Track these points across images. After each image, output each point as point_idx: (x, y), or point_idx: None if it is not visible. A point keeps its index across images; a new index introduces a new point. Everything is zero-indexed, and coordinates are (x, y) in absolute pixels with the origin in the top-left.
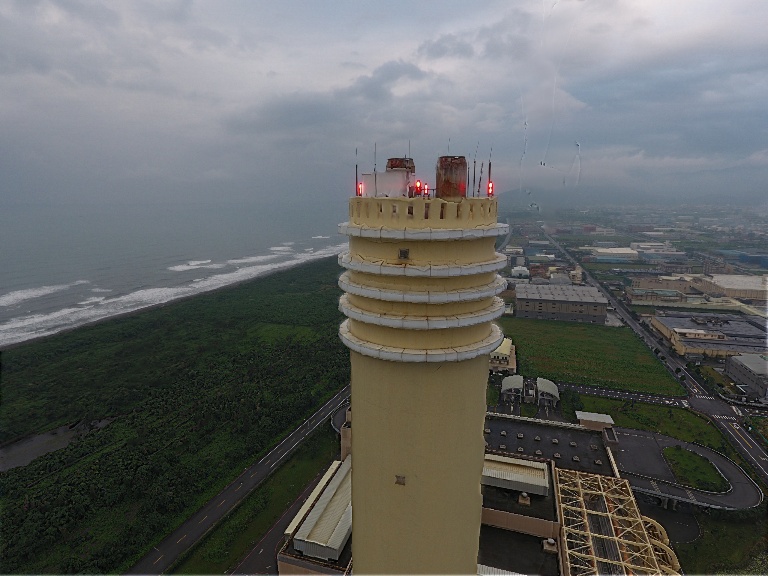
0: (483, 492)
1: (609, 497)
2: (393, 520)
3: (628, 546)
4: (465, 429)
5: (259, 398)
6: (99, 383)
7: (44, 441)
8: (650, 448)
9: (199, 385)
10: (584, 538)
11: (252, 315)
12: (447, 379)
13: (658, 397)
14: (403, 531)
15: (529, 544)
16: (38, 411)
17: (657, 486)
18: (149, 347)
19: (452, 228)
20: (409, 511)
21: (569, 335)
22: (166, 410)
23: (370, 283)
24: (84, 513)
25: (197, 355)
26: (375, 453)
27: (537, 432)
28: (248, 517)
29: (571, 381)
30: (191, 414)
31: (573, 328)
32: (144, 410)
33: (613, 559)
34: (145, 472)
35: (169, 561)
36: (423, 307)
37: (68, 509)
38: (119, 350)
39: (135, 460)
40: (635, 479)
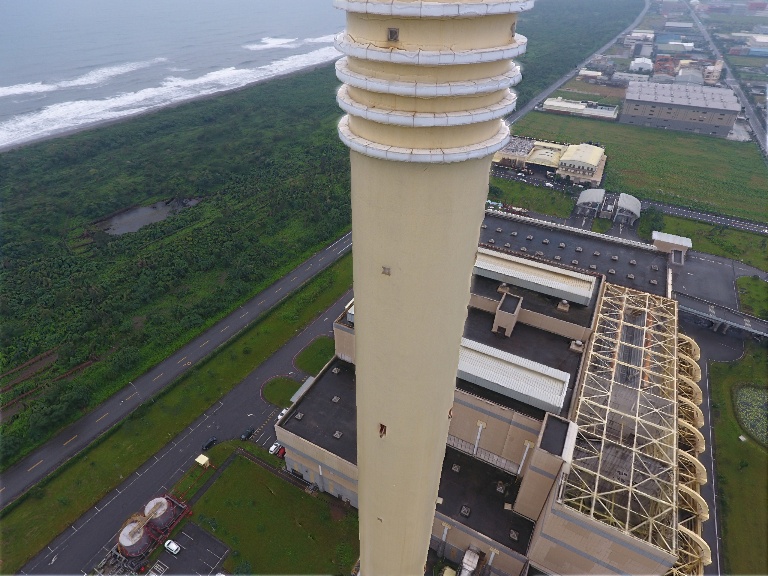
0: (525, 295)
1: (651, 314)
2: (380, 303)
3: (655, 356)
4: (451, 232)
5: (329, 191)
6: (186, 165)
7: (147, 213)
8: (723, 275)
9: (275, 174)
10: (612, 344)
11: (327, 104)
12: (434, 181)
13: (757, 225)
14: (388, 312)
15: (557, 343)
16: (138, 187)
17: (714, 310)
18: (228, 133)
19: (451, 2)
20: (393, 297)
21: (676, 148)
22: (246, 195)
23: (361, 70)
24: (184, 274)
25: (272, 144)
26: (366, 245)
27: (598, 247)
28: (316, 292)
29: (660, 199)
30: (268, 200)
31: (684, 140)
32: (227, 193)
33: (635, 364)
34: (230, 247)
35: (252, 317)
36: (412, 101)
37: (172, 269)
38: (201, 134)
39: (221, 236)
40: (693, 302)
